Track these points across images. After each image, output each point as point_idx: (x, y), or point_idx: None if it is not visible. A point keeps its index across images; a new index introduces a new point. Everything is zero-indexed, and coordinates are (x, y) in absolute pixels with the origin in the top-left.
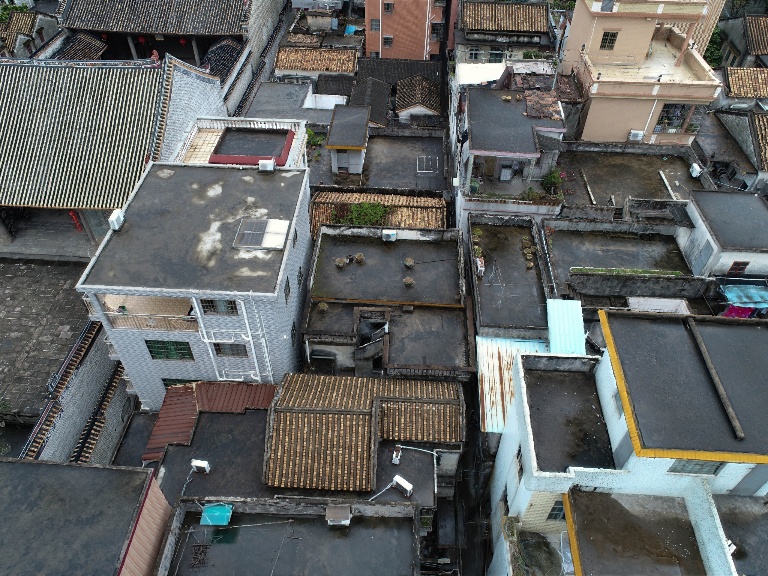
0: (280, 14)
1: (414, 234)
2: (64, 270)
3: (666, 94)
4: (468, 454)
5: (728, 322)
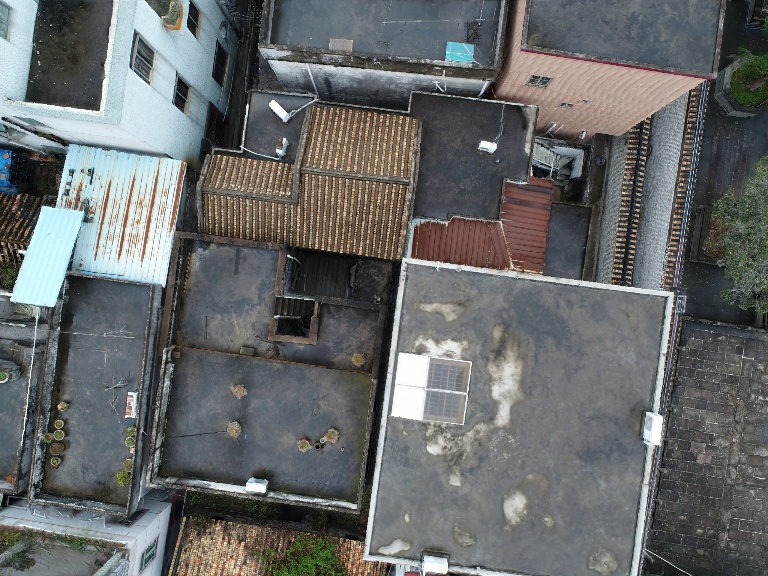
0: None
1: (220, 487)
2: (737, 569)
3: None
4: None
5: None
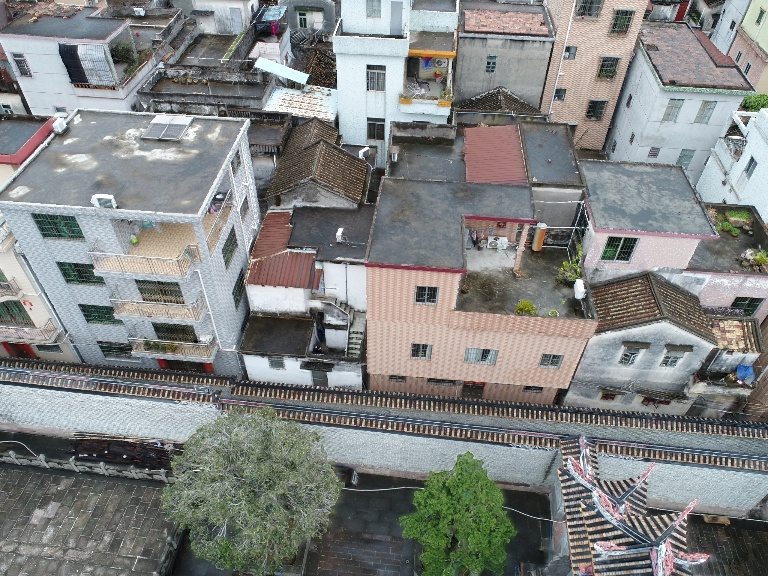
0: None
1: None
2: None
3: None
4: None
5: None
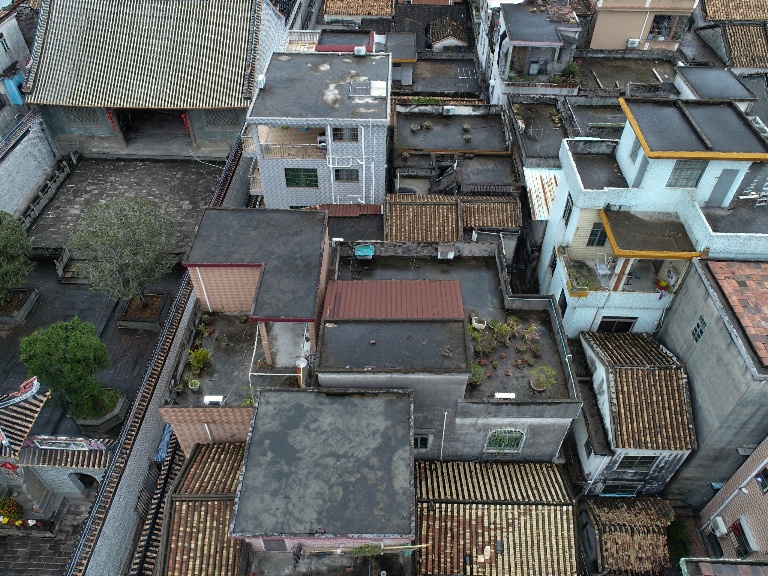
0: None
1: (467, 110)
2: (174, 165)
3: (656, 7)
4: (519, 253)
5: (703, 103)
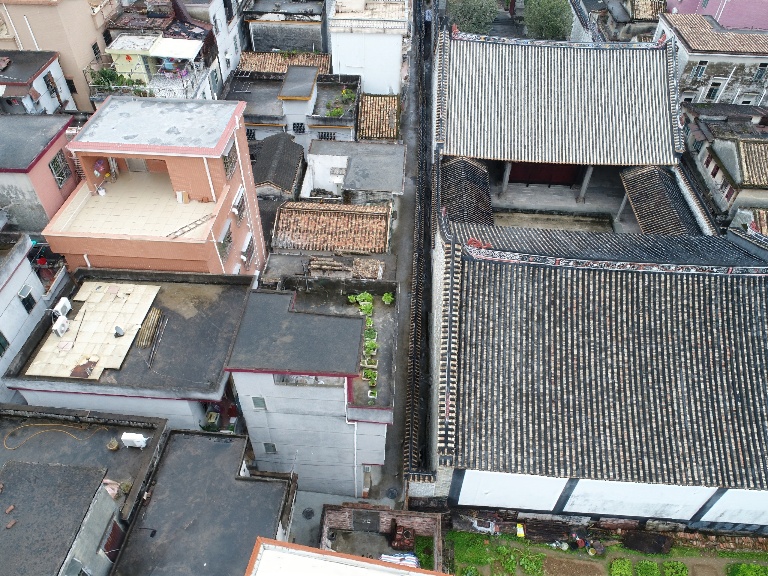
0: (417, 357)
1: (269, 15)
2: None
3: None
4: None
5: None
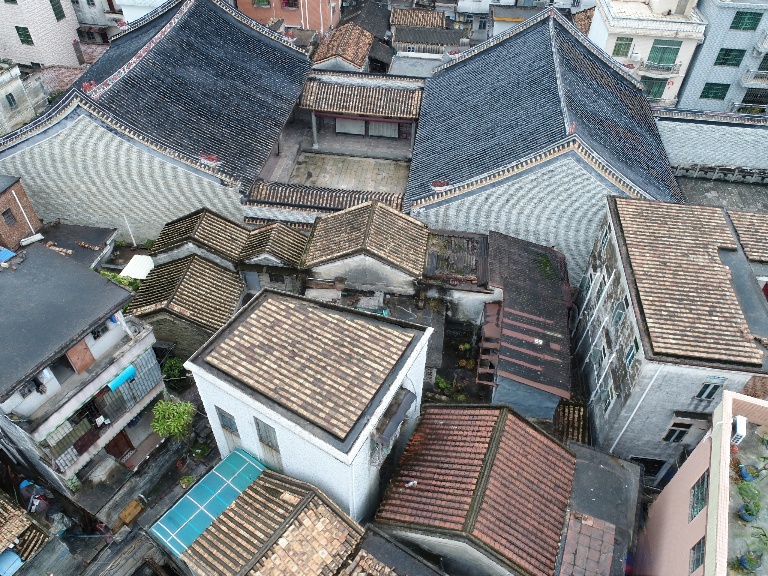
0: None
1: None
2: None
3: None
4: None
5: None
